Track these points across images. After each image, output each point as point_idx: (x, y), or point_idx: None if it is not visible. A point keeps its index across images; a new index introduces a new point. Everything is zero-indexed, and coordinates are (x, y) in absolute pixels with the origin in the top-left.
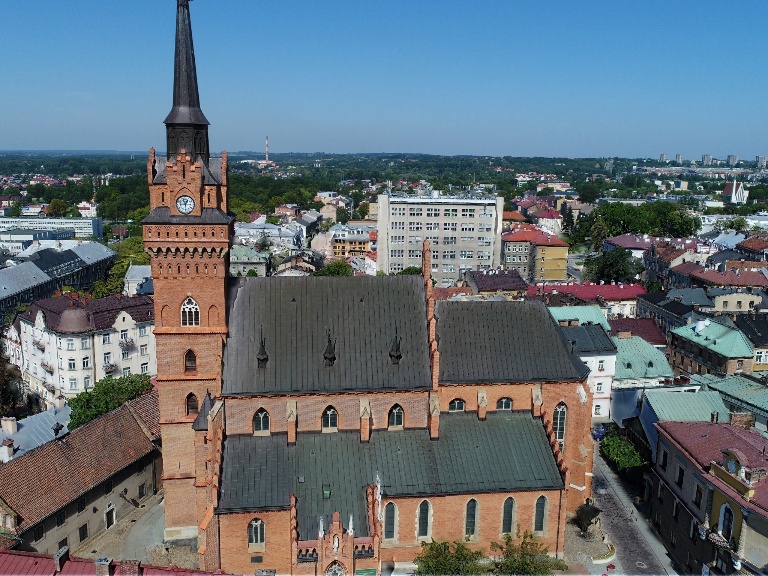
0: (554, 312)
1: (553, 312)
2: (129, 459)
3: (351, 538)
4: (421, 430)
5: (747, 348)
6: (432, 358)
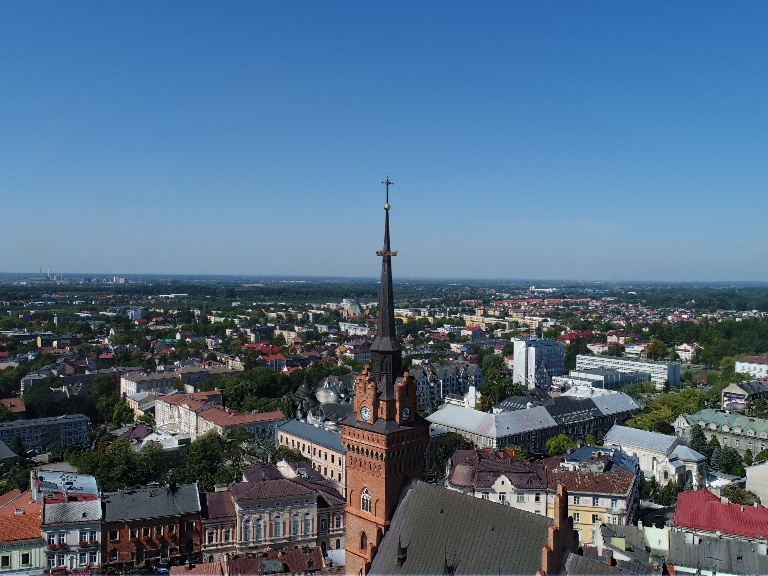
0: None
1: None
2: None
3: None
4: None
5: None
6: None
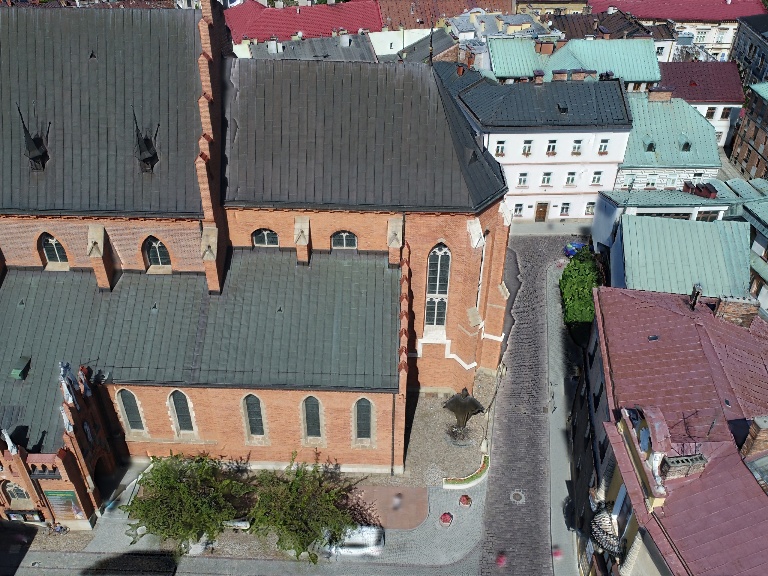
0: (580, 48)
1: (578, 48)
2: None
3: (15, 458)
4: (199, 275)
5: None
6: None
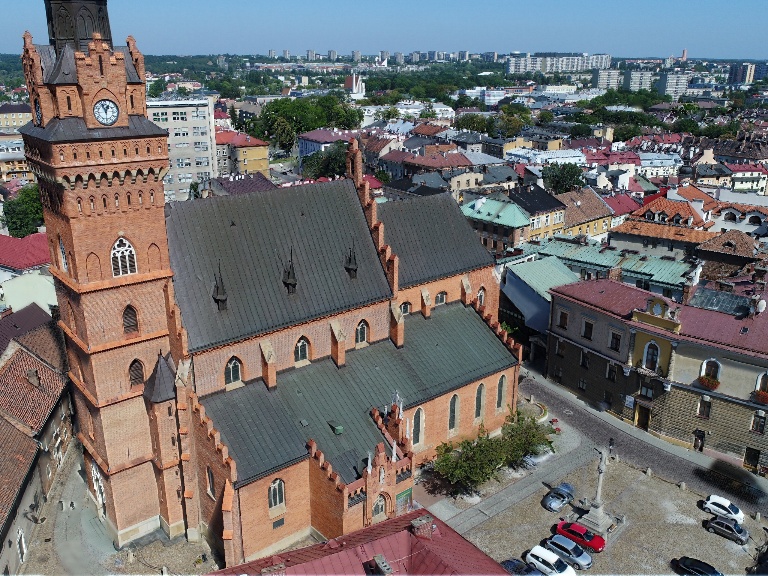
0: None
1: None
2: (22, 467)
3: (395, 465)
4: (384, 341)
5: (524, 217)
6: (390, 265)
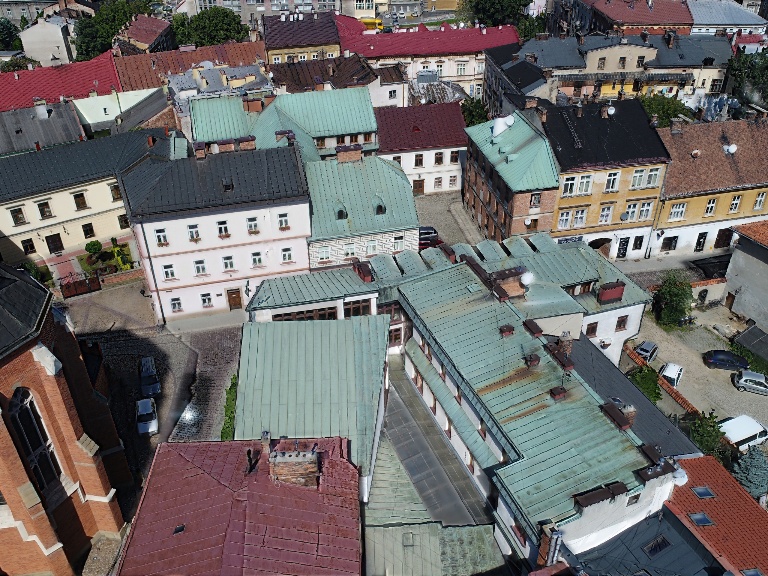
0: (288, 103)
1: (287, 103)
2: None
3: None
4: None
5: (551, 172)
6: None
